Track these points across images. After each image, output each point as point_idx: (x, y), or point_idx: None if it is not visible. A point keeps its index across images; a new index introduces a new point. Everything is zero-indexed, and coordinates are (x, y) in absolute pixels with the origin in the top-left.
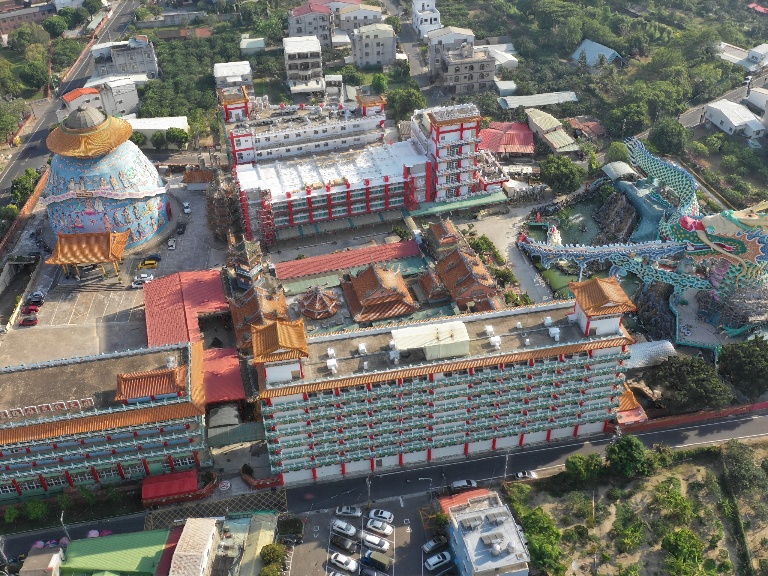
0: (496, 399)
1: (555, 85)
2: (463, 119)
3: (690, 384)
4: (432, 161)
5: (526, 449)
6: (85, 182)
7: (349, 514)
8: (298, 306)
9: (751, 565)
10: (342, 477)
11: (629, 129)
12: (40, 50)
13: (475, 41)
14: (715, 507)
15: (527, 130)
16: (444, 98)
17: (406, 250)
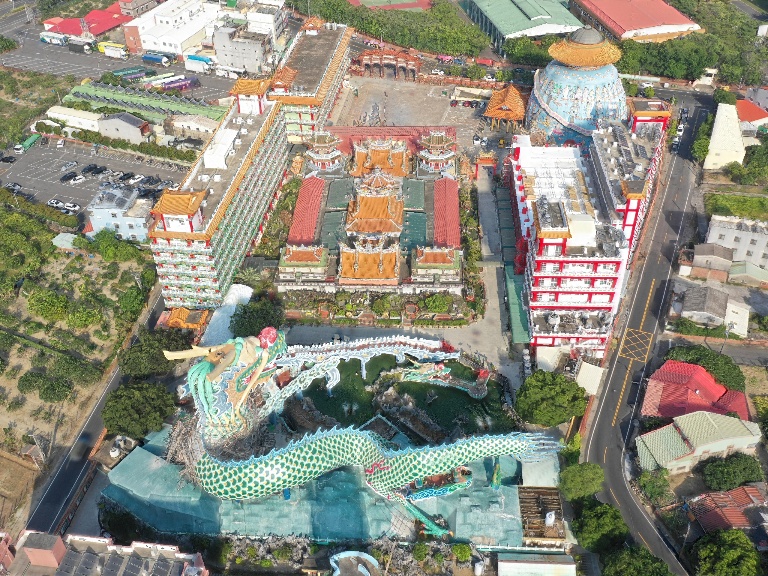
0: None
1: None
2: None
3: None
4: None
5: None
6: None
7: None
8: None
9: (17, 336)
10: None
11: None
12: None
13: None
14: None
15: None
16: None
17: None
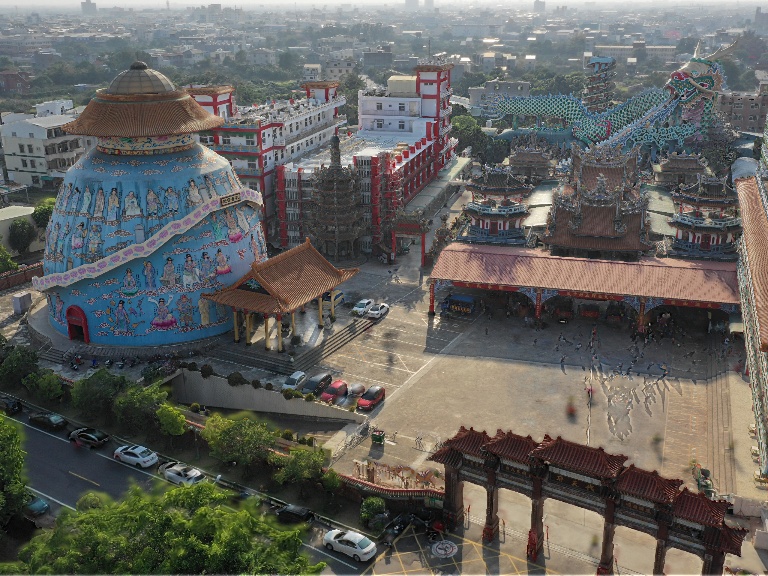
0: None
1: None
2: (447, 65)
3: None
4: None
5: None
6: (213, 183)
7: None
8: None
9: None
10: None
11: None
12: None
13: None
14: None
15: None
16: None
17: None
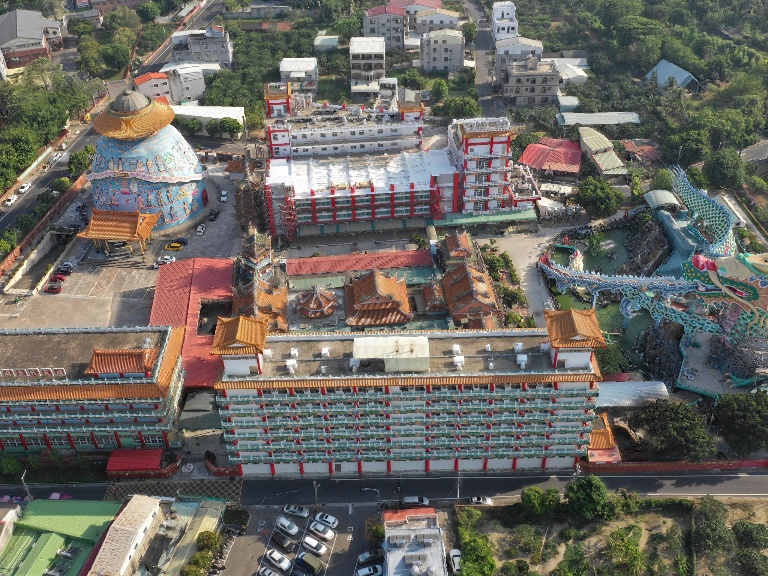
0: (455, 420)
1: (620, 105)
2: (493, 133)
3: (670, 431)
4: (461, 172)
5: (489, 474)
6: (123, 163)
7: (296, 513)
8: (296, 303)
9: None
10: (300, 476)
11: (686, 157)
12: (127, 33)
13: (549, 53)
14: (672, 563)
15: (577, 149)
16: (503, 109)
17: (419, 259)
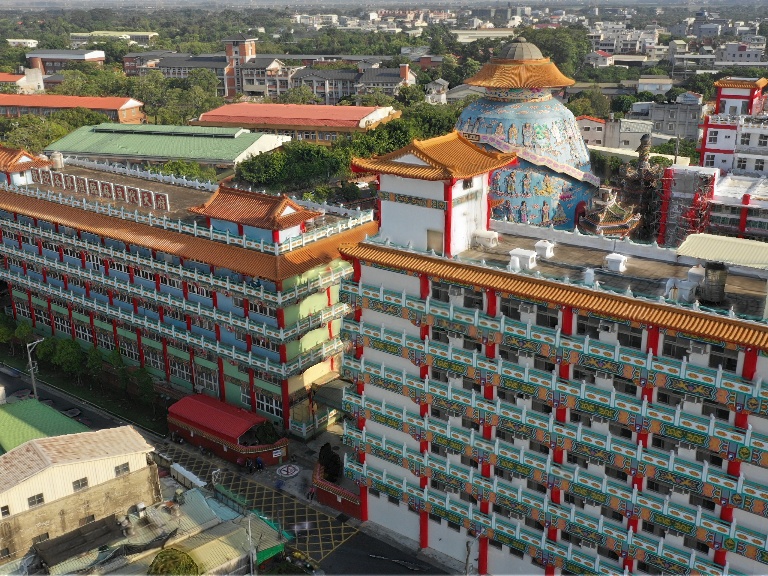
0: None
1: None
2: None
3: None
4: None
5: None
6: (480, 124)
7: None
8: None
9: None
10: (472, 575)
11: None
12: (585, 104)
13: None
14: None
15: None
16: None
17: None
